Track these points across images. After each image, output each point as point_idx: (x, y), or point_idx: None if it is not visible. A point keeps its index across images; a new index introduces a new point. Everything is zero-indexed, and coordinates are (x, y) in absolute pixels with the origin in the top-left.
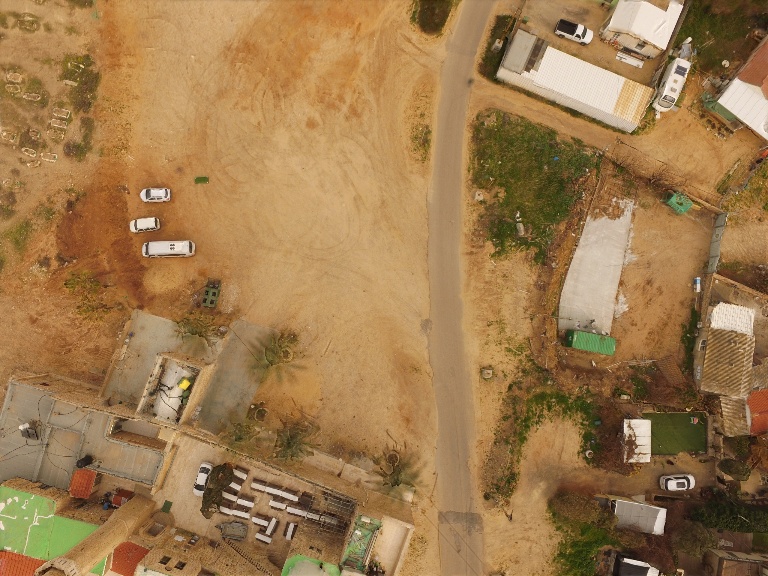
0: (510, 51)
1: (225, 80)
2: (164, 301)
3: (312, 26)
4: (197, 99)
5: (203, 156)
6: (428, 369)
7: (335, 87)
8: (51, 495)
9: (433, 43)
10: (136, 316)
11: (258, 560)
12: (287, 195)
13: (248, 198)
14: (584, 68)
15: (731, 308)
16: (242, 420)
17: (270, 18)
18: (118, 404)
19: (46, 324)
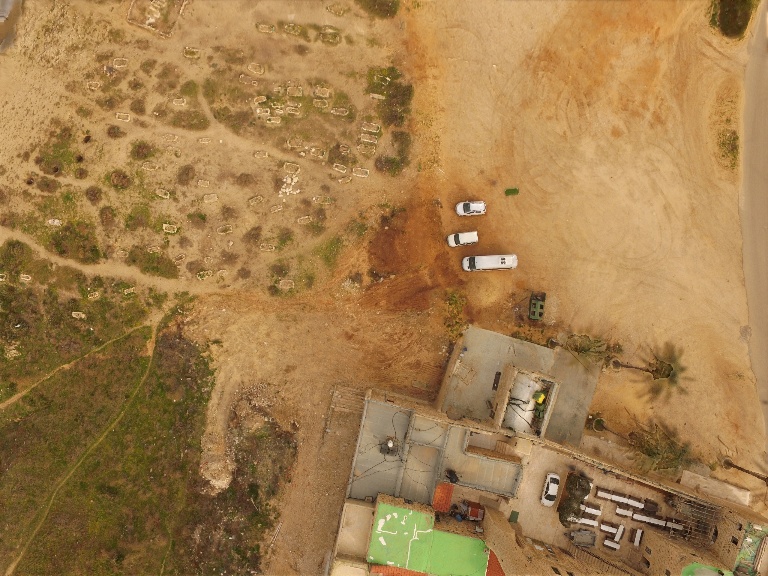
0: None
1: (529, 89)
2: (491, 315)
3: (611, 32)
4: (502, 110)
5: (512, 167)
6: (750, 375)
7: (638, 94)
8: (425, 510)
9: (735, 46)
10: None
11: (622, 567)
12: (597, 205)
13: (559, 209)
14: None
15: None
16: (580, 430)
17: (570, 25)
18: (464, 418)
19: (363, 340)
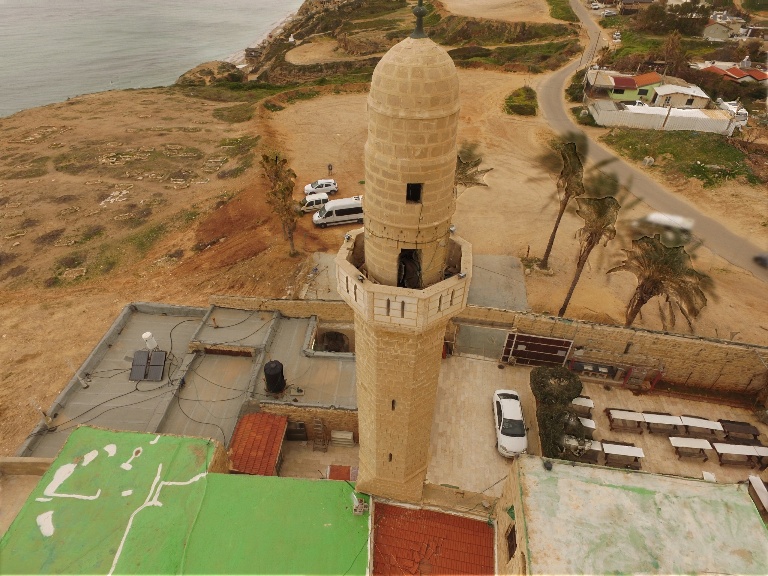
0: (600, 105)
1: None
2: None
3: None
4: (348, 149)
5: (363, 171)
6: (737, 269)
7: (468, 138)
8: None
9: (533, 118)
10: (318, 257)
11: None
12: None
13: None
14: (662, 108)
15: None
16: None
17: None
18: None
19: None
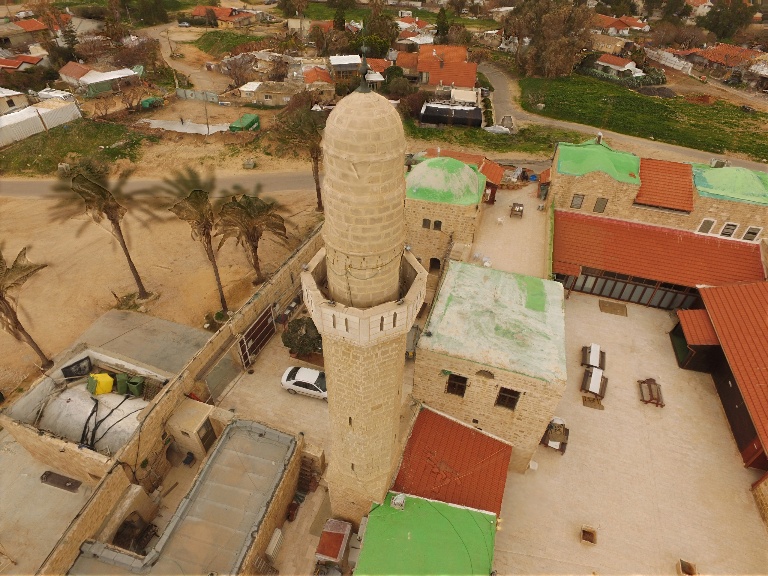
0: None
1: None
2: None
3: None
4: None
5: None
6: None
7: None
8: None
9: None
10: None
11: None
12: None
13: None
14: None
15: (244, 86)
16: None
17: None
18: None
19: None
